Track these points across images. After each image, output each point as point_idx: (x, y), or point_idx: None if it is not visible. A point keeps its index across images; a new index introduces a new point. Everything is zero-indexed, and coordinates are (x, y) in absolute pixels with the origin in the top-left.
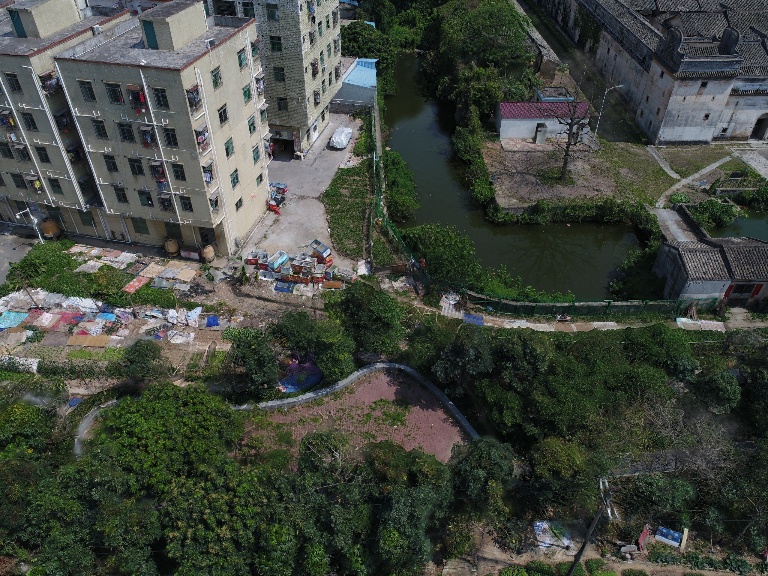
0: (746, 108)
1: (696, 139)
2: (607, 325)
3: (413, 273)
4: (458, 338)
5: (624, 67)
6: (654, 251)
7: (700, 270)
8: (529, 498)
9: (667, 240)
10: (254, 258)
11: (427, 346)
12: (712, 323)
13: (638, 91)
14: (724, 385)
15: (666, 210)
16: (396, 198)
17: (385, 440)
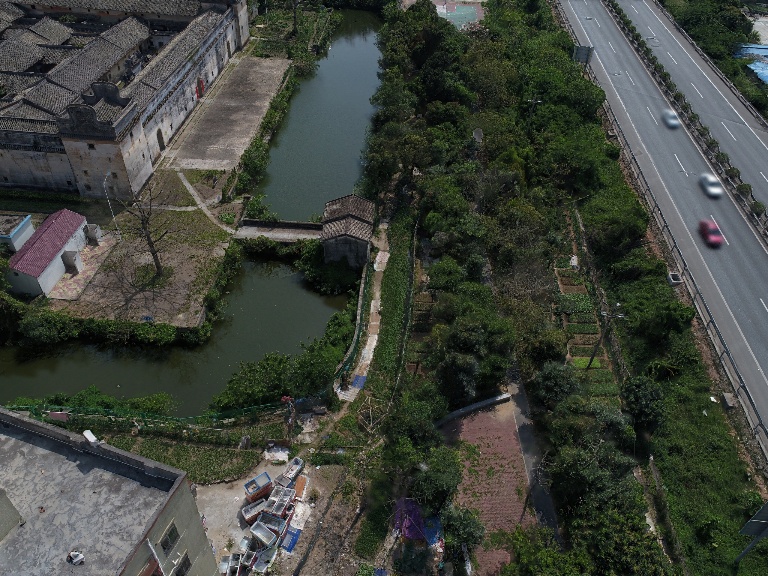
0: (149, 134)
1: (147, 177)
2: (374, 305)
3: (296, 412)
4: (462, 366)
5: (2, 162)
6: (315, 251)
7: (364, 234)
8: (533, 384)
9: (288, 242)
10: (238, 571)
11: (439, 399)
12: (380, 255)
13: (53, 173)
14: (482, 260)
15: (240, 230)
16: (155, 407)
17: (557, 426)
